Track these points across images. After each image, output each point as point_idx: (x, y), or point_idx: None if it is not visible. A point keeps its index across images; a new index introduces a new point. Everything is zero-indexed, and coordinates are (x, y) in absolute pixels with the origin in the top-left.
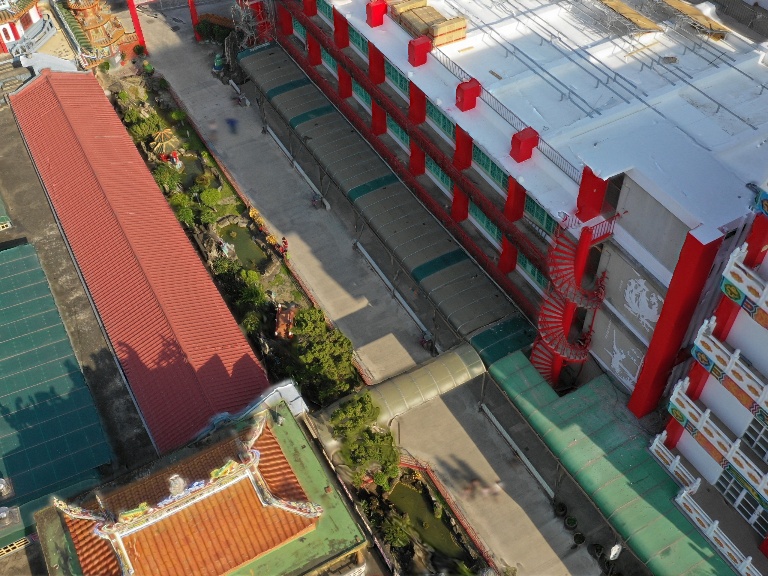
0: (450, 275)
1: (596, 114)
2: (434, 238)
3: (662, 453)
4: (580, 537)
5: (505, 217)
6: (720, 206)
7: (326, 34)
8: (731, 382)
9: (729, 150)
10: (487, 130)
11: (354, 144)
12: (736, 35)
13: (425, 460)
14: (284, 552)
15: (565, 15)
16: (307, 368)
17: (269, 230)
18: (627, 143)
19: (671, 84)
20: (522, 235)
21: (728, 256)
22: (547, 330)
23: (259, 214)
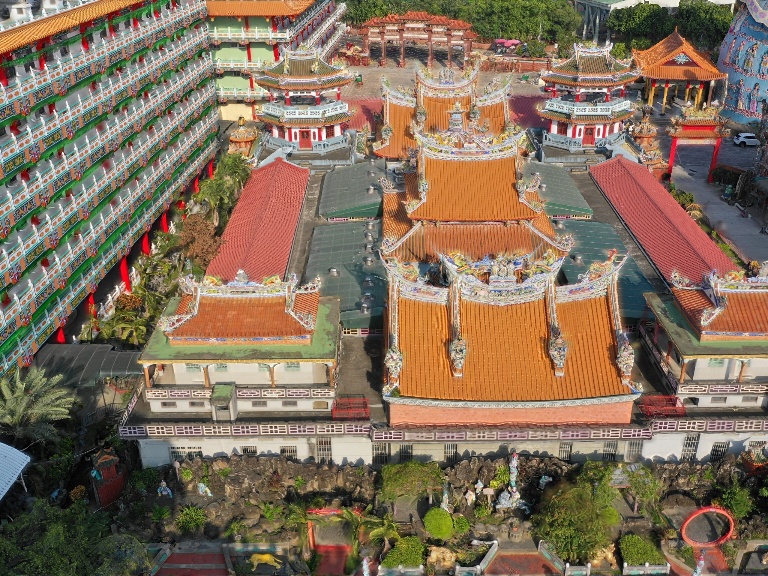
0: None
1: None
2: None
3: None
4: None
5: None
6: None
7: None
8: None
9: None
10: None
11: None
12: None
13: None
14: None
15: None
16: None
17: None
18: None
19: None
20: None
21: None
22: None
23: None
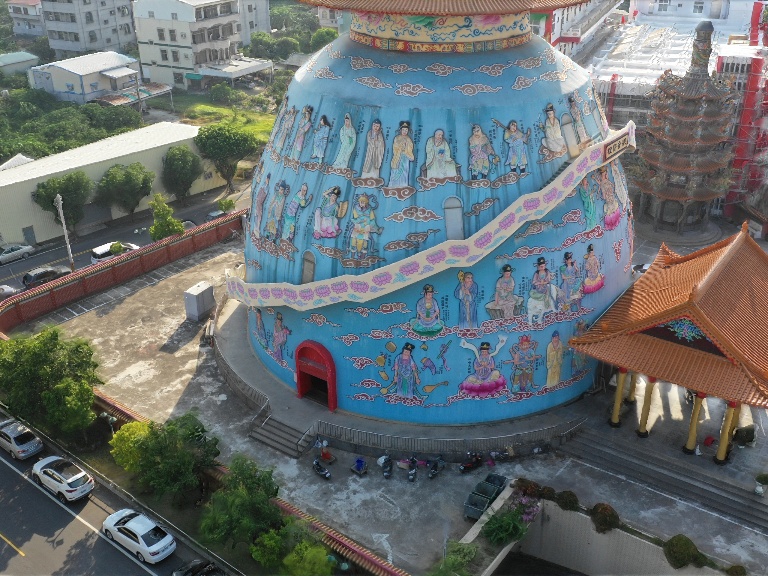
0: None
1: (718, 31)
2: None
3: None
4: None
5: None
6: None
7: None
8: None
9: None
10: None
11: None
12: None
13: None
14: None
15: None
16: None
17: None
18: None
19: None
20: None
21: None
22: None
23: None
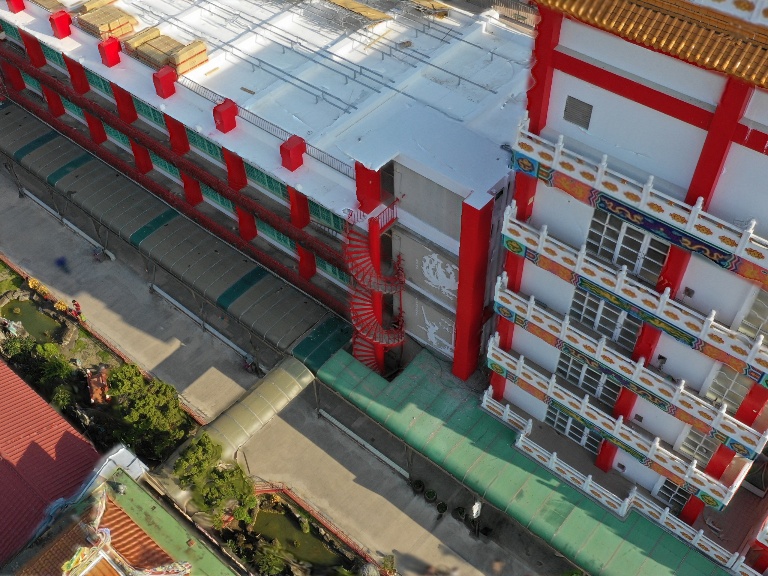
0: (255, 295)
1: (353, 109)
2: (230, 262)
3: (493, 406)
4: (442, 506)
5: (293, 226)
6: (484, 171)
7: (62, 83)
8: (534, 326)
9: (478, 117)
10: (254, 146)
11: (123, 188)
12: (457, 11)
13: (279, 481)
14: None
15: (299, 20)
16: (135, 427)
17: (55, 297)
18: (388, 132)
19: (412, 67)
20: (314, 239)
21: (502, 214)
22: (361, 323)
23: (40, 283)
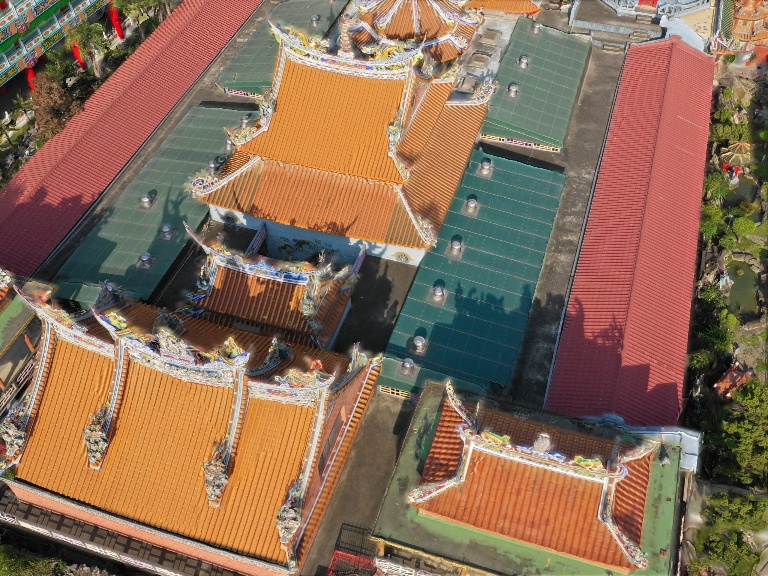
0: None
1: None
2: None
3: None
4: None
5: None
6: None
7: None
8: None
9: None
10: None
11: None
12: None
13: None
14: (587, 569)
15: None
16: (723, 436)
17: None
18: None
19: None
20: None
21: None
22: None
23: None
